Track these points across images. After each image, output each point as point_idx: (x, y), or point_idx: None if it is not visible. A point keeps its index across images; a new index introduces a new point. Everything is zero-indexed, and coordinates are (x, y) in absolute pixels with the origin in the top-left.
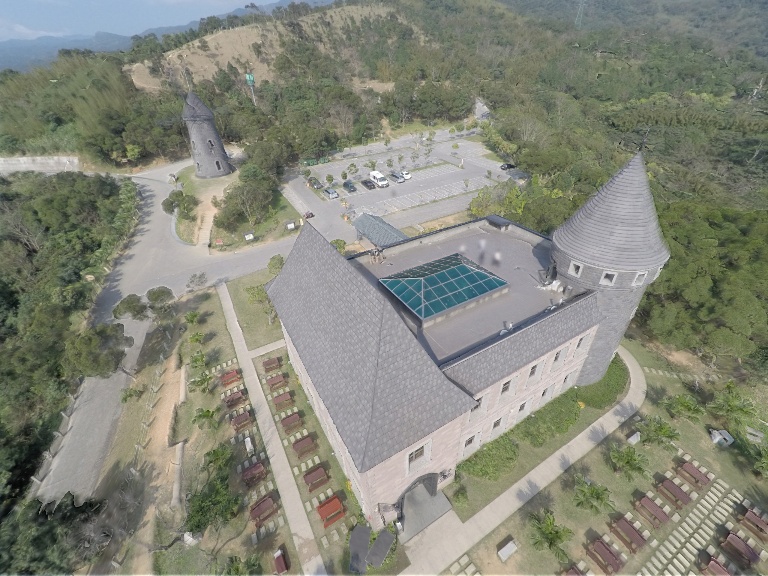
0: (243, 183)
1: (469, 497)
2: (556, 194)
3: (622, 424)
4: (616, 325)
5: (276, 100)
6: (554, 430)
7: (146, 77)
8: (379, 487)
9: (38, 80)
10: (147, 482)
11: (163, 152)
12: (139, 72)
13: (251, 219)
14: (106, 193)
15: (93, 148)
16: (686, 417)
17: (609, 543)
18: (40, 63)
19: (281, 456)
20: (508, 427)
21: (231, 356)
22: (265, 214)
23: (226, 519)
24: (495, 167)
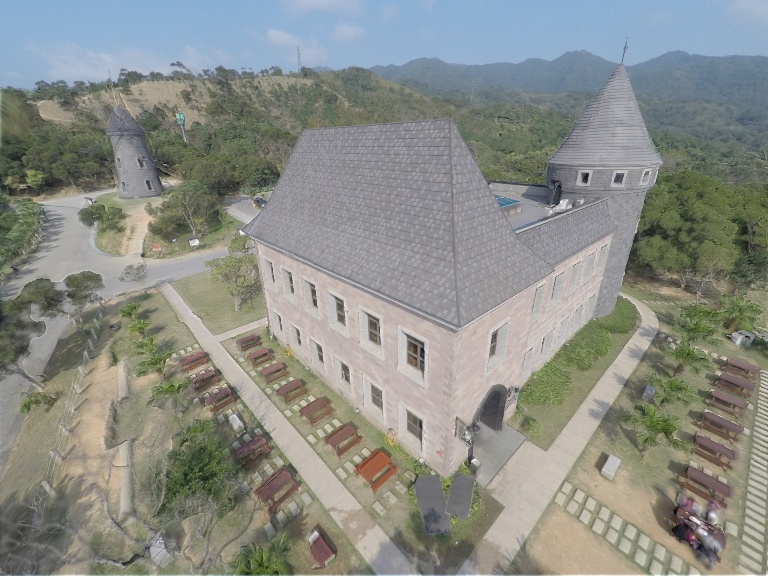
0: None
1: None
2: None
3: (652, 341)
4: (626, 237)
5: (210, 139)
6: (594, 353)
7: (55, 112)
8: (461, 384)
9: None
10: (72, 498)
11: (75, 181)
12: (46, 107)
13: (197, 221)
14: None
15: None
16: (708, 321)
17: None
18: None
19: (286, 427)
20: (550, 355)
21: (190, 342)
22: (209, 228)
23: (223, 505)
24: None
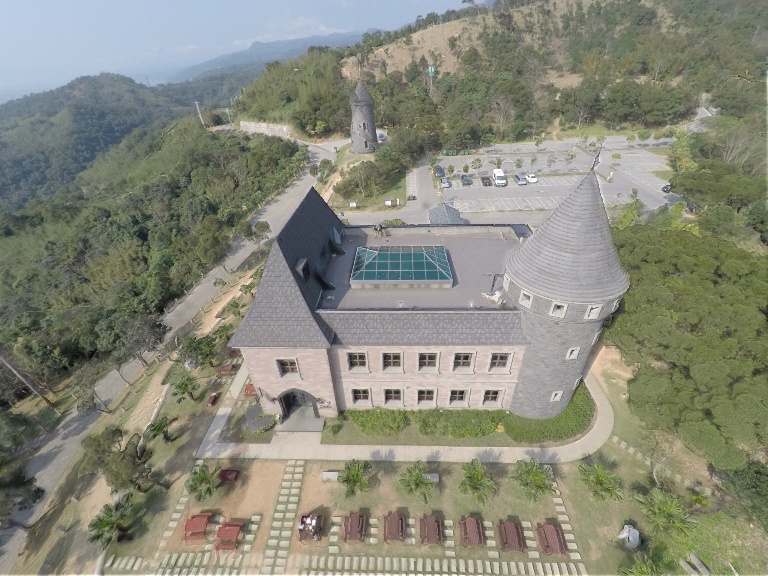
0: (373, 161)
1: (339, 433)
2: (688, 229)
3: None
4: (545, 358)
5: (448, 91)
6: (449, 430)
7: None
8: (256, 373)
9: (288, 69)
10: (194, 330)
11: (341, 129)
12: None
13: (357, 190)
14: (287, 154)
15: (296, 121)
16: (592, 490)
17: (411, 525)
18: (293, 56)
19: None
20: (409, 406)
21: None
22: (381, 190)
23: (204, 362)
24: (656, 187)
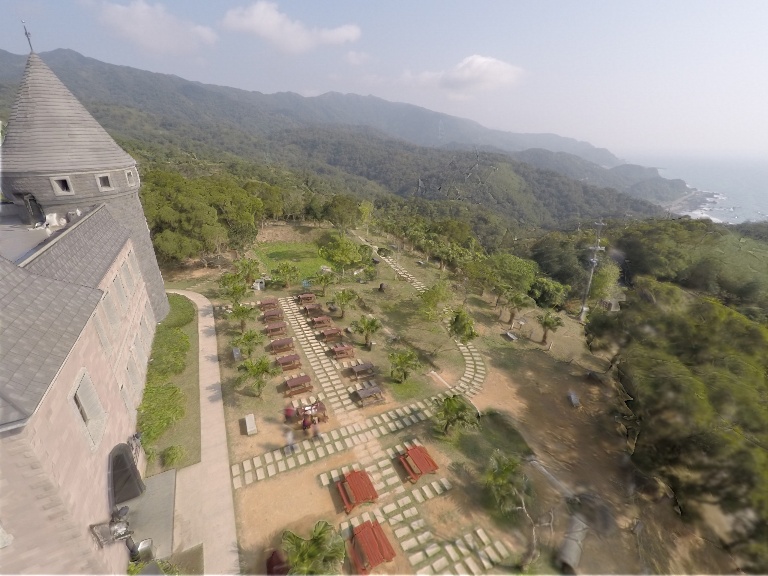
0: None
1: None
2: None
3: (214, 316)
4: (144, 238)
5: None
6: (180, 352)
7: None
8: (70, 486)
9: None
10: None
11: None
12: None
13: None
14: None
15: None
16: None
17: None
18: None
19: None
20: None
21: None
22: None
23: None
24: None
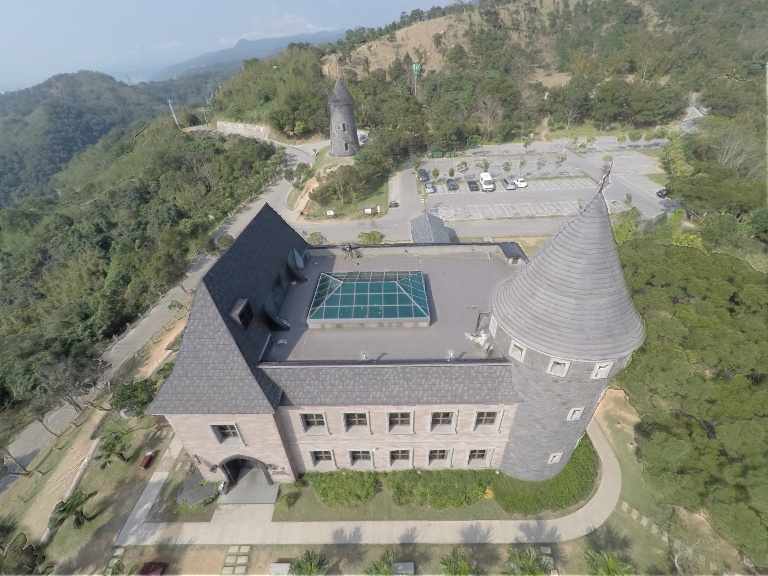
0: (352, 165)
1: (296, 504)
2: (691, 241)
3: (518, 543)
4: (541, 418)
5: (434, 90)
6: (428, 499)
7: None
8: (189, 440)
9: (266, 66)
10: (138, 366)
11: (322, 130)
12: None
13: (334, 197)
14: (263, 157)
15: (273, 121)
16: None
17: None
18: (271, 53)
19: None
20: (381, 467)
21: None
22: (361, 196)
23: (141, 412)
24: (650, 192)
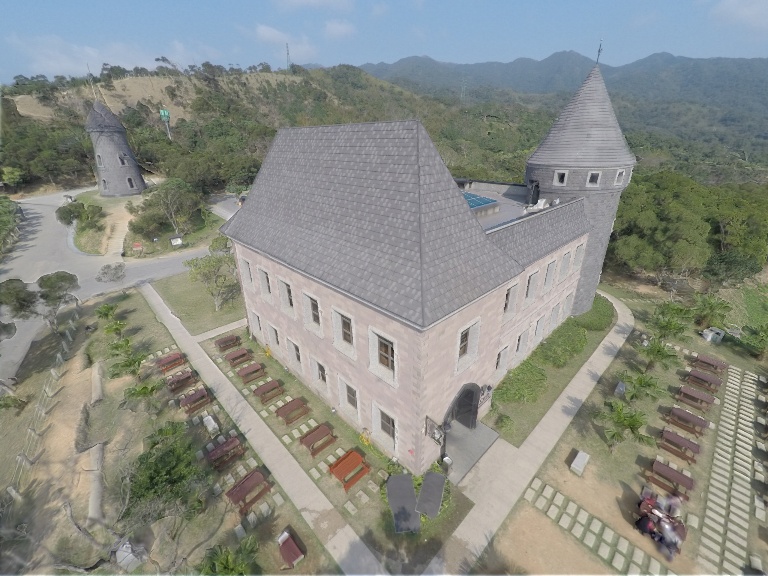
0: None
1: None
2: None
3: (627, 339)
4: (602, 236)
5: (195, 136)
6: (570, 351)
7: (34, 107)
8: (429, 383)
9: None
10: (39, 504)
11: (54, 179)
12: (24, 102)
13: (179, 220)
14: None
15: None
16: (680, 319)
17: None
18: None
19: (261, 428)
20: (526, 353)
21: (168, 343)
22: (192, 227)
23: (192, 508)
24: None
